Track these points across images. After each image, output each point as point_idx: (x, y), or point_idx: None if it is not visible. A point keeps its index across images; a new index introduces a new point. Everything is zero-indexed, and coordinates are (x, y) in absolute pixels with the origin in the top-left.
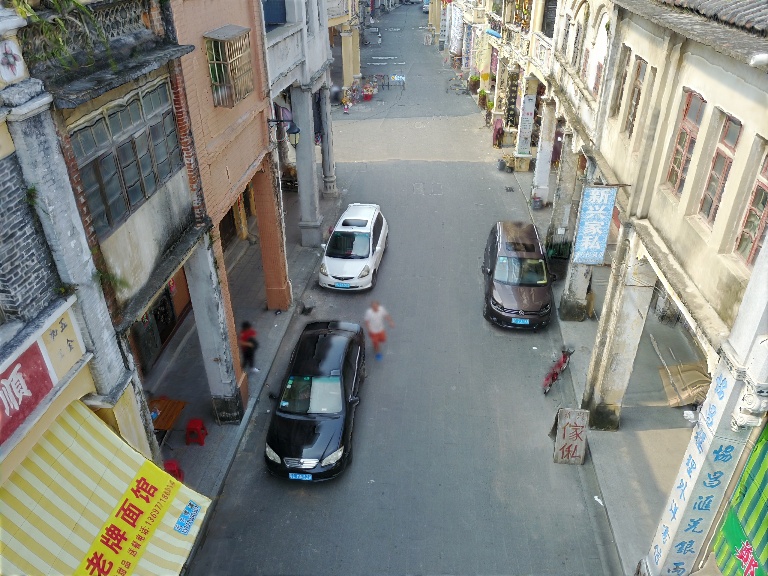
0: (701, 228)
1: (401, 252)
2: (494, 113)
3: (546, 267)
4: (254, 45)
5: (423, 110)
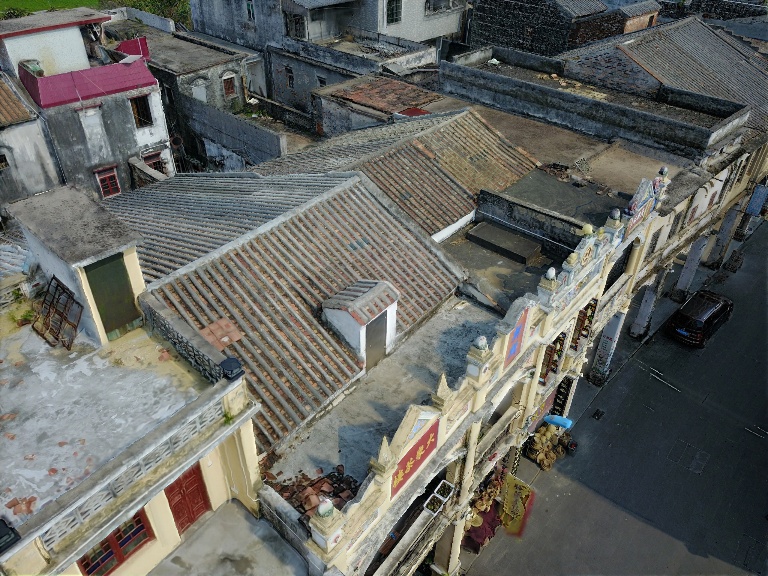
0: (765, 160)
1: (760, 387)
2: None
3: None
4: None
5: None
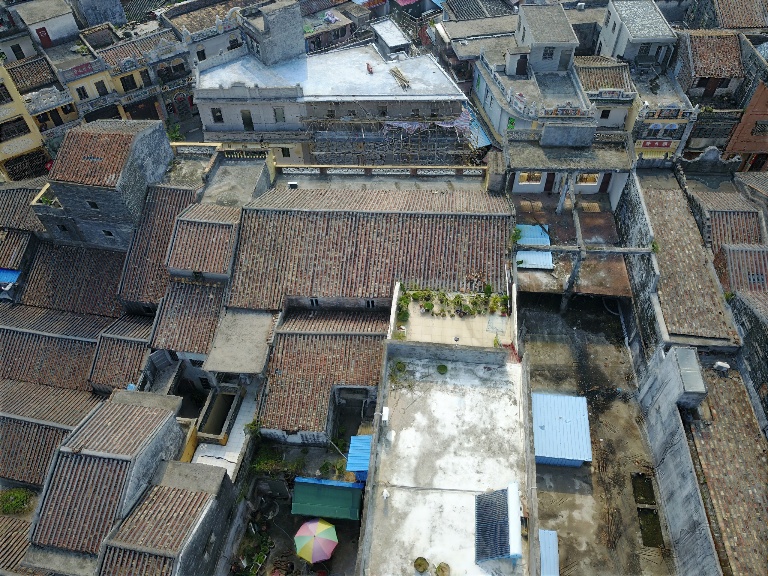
0: None
1: None
2: None
3: None
4: None
5: None
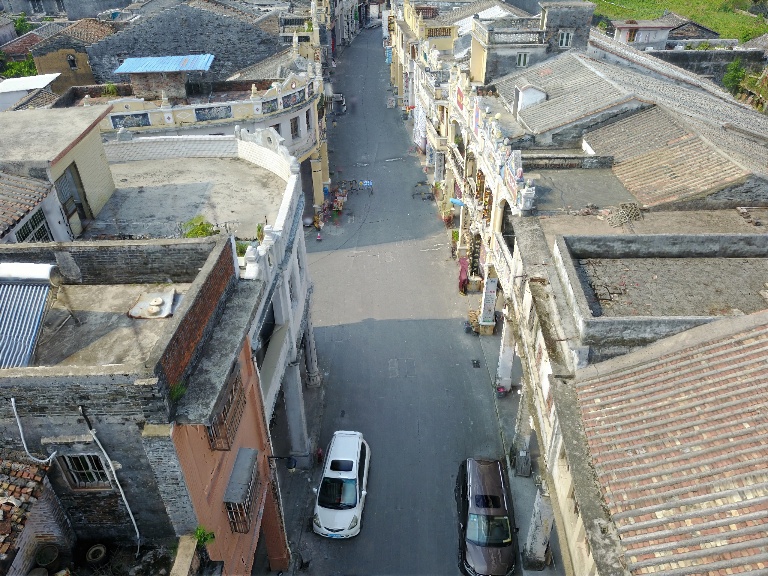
0: None
1: (383, 471)
2: (459, 248)
3: (510, 524)
4: (256, 420)
5: (392, 230)
